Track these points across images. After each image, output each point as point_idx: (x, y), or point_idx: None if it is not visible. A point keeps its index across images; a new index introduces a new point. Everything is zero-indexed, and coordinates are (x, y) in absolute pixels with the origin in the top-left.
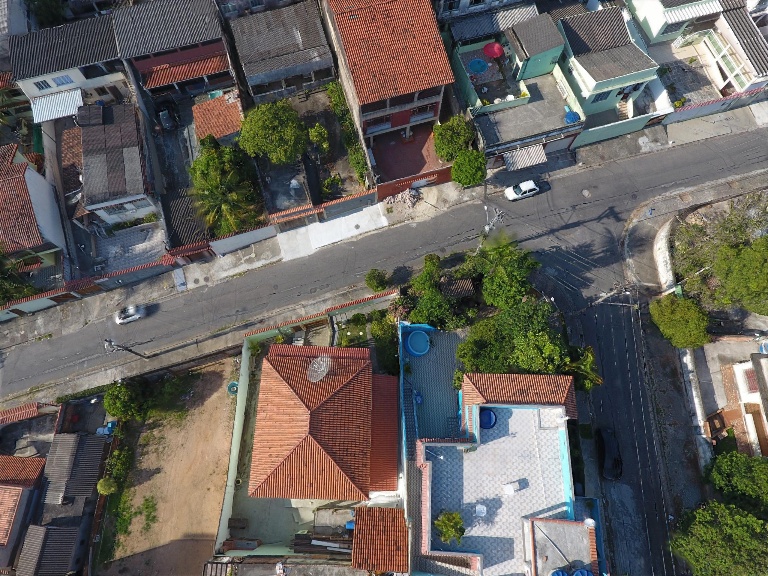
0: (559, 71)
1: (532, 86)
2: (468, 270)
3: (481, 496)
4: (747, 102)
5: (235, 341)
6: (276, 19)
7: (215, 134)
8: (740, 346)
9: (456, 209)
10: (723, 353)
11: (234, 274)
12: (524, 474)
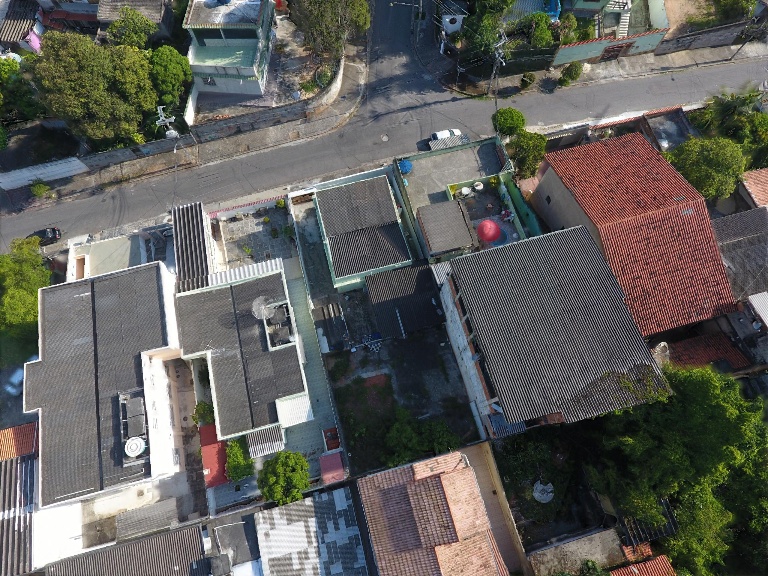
0: None
1: None
2: None
3: None
4: None
5: (668, 61)
6: (762, 278)
7: (767, 174)
8: None
9: None
10: None
11: (686, 106)
12: None
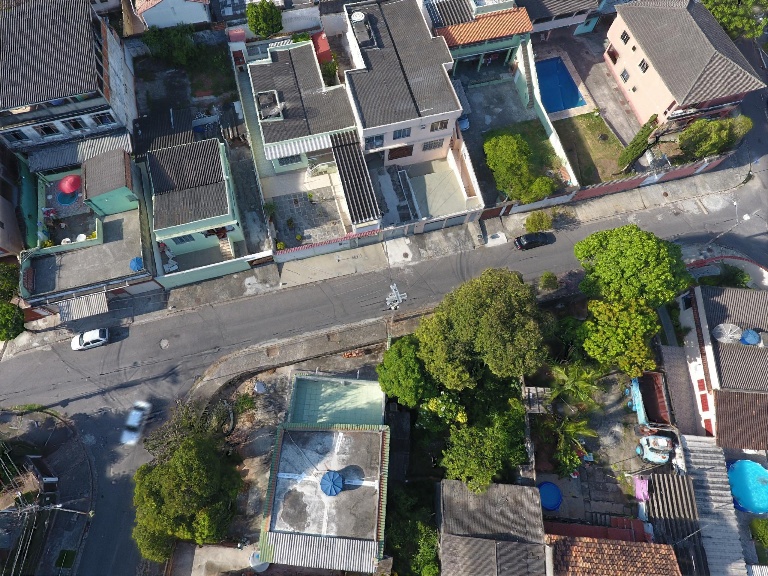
0: (138, 210)
1: (117, 222)
2: None
3: None
4: (378, 239)
5: None
6: None
7: None
8: (235, 552)
9: (22, 356)
10: (213, 560)
11: None
12: None
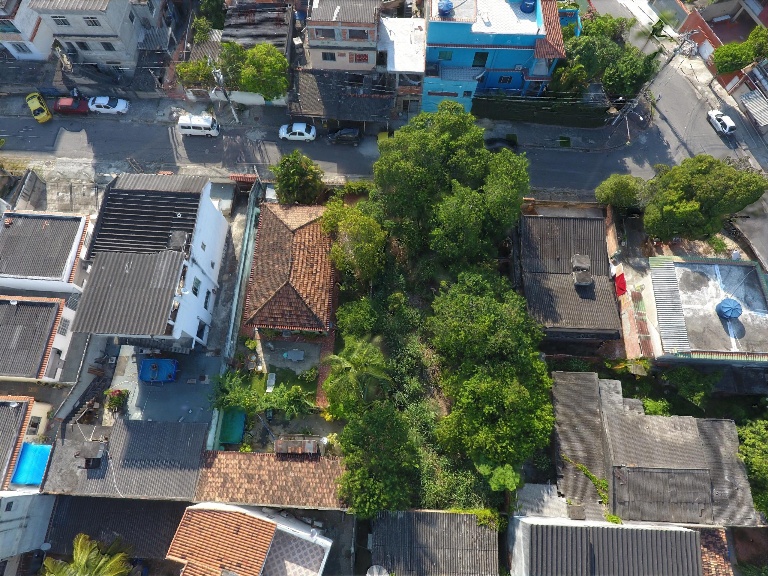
0: None
1: None
2: (633, 53)
3: (478, 3)
4: None
5: None
6: None
7: None
8: None
9: (687, 82)
10: None
11: None
12: (494, 25)
